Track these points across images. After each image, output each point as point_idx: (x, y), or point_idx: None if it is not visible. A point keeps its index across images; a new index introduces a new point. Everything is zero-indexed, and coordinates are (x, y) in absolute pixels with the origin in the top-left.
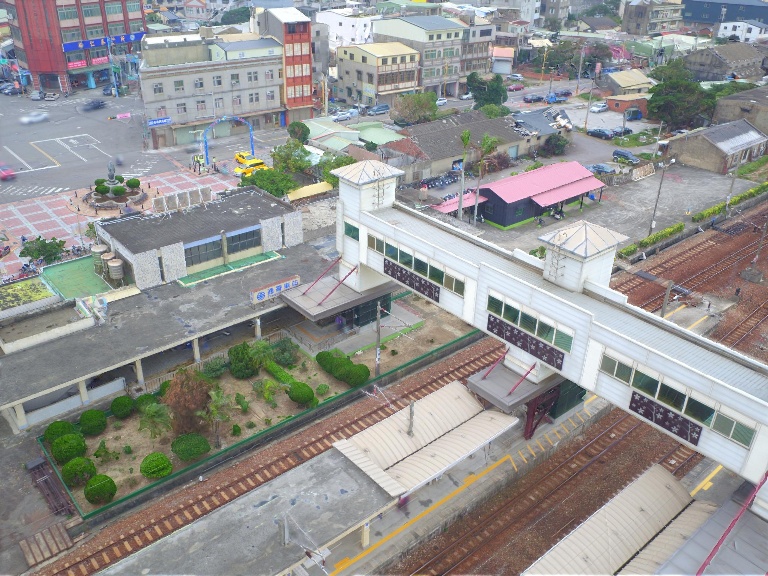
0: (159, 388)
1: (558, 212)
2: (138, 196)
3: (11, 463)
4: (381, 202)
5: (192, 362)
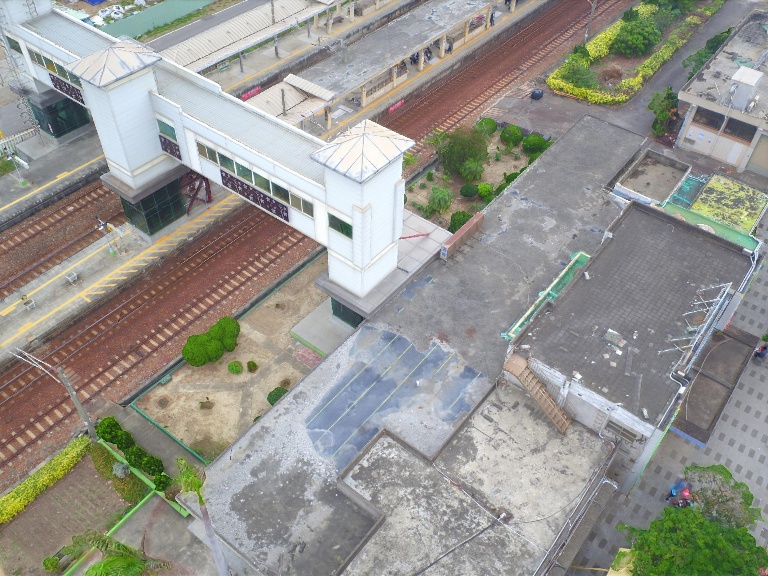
0: None
1: None
2: None
3: None
4: None
5: None
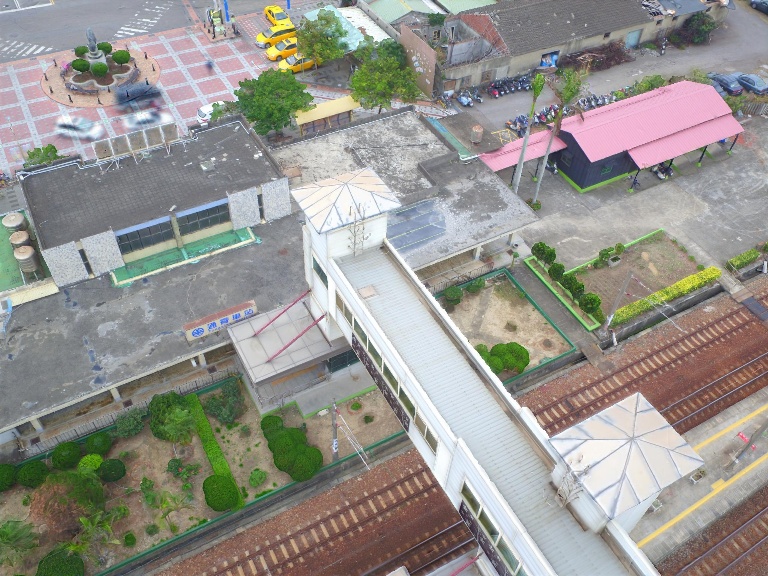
0: (58, 444)
1: (664, 170)
2: (127, 74)
3: None
4: (363, 242)
5: (110, 400)
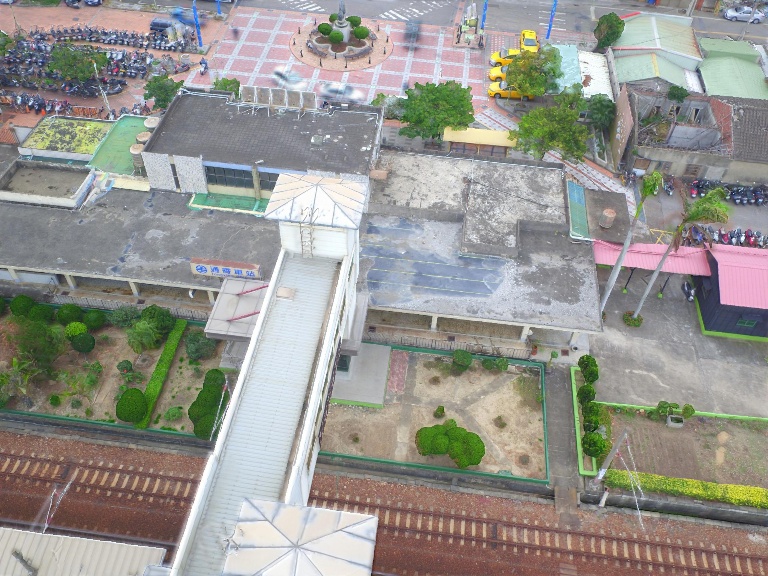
0: (74, 304)
1: None
2: (360, 49)
3: None
4: (321, 249)
5: (131, 293)
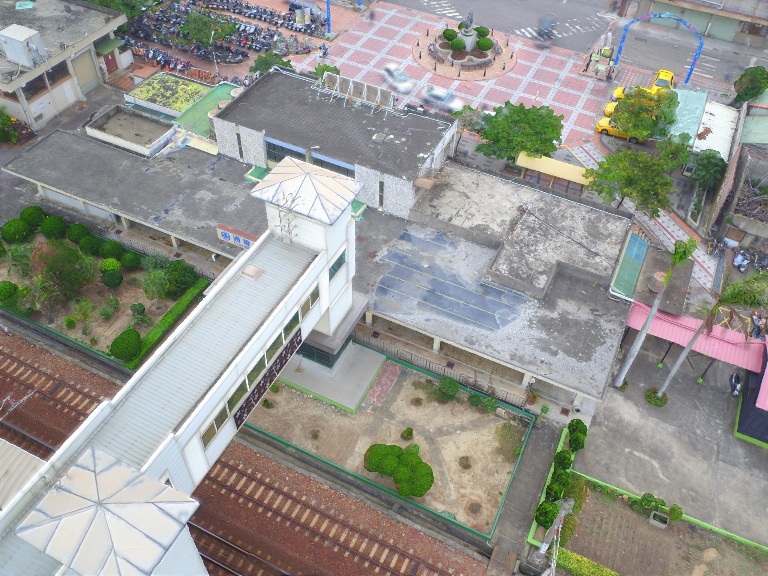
0: (121, 243)
1: None
2: (479, 60)
3: (1, 212)
4: (303, 238)
5: None
